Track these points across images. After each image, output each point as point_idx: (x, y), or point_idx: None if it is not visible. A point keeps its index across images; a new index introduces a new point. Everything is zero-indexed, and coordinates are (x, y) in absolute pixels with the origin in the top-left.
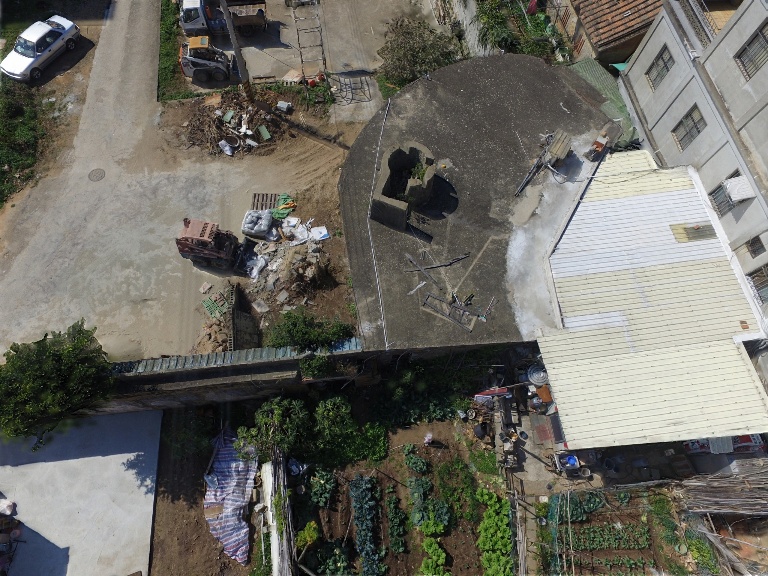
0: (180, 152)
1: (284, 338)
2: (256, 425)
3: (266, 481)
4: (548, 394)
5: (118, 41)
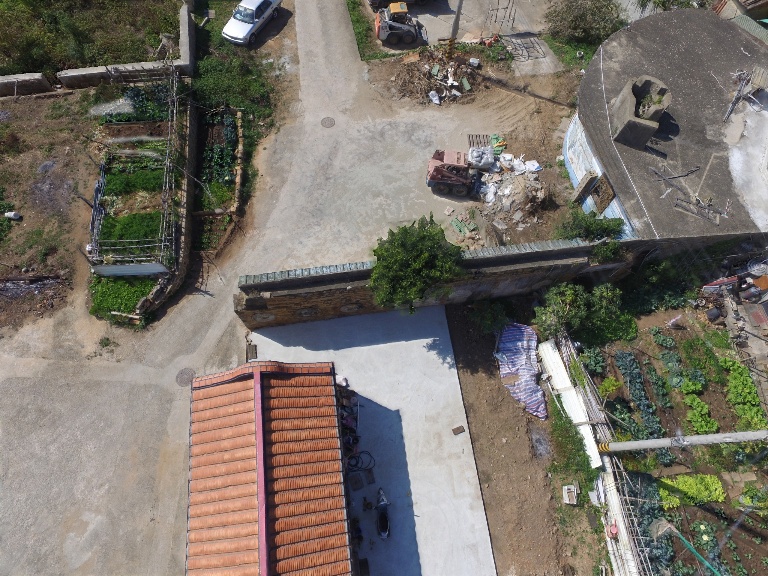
0: (394, 102)
1: (575, 231)
2: (549, 305)
3: (545, 357)
4: (767, 282)
5: (312, 10)
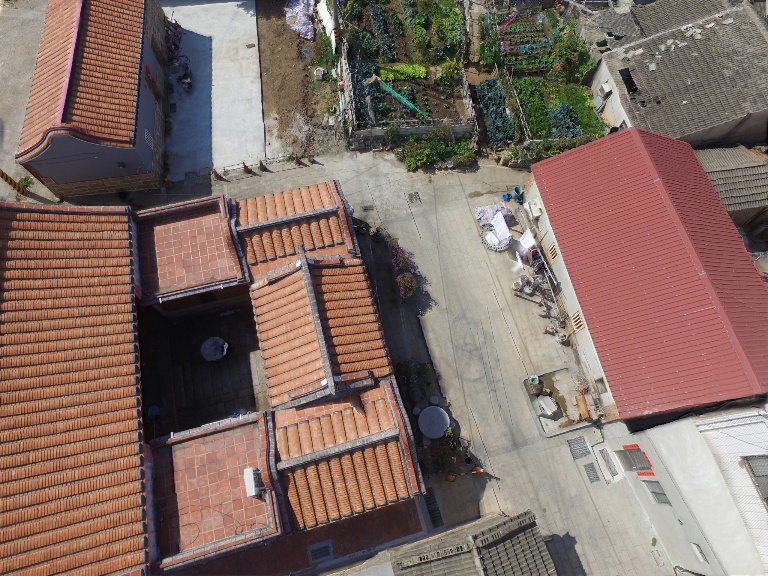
0: None
1: None
2: None
3: (320, 10)
4: None
5: None
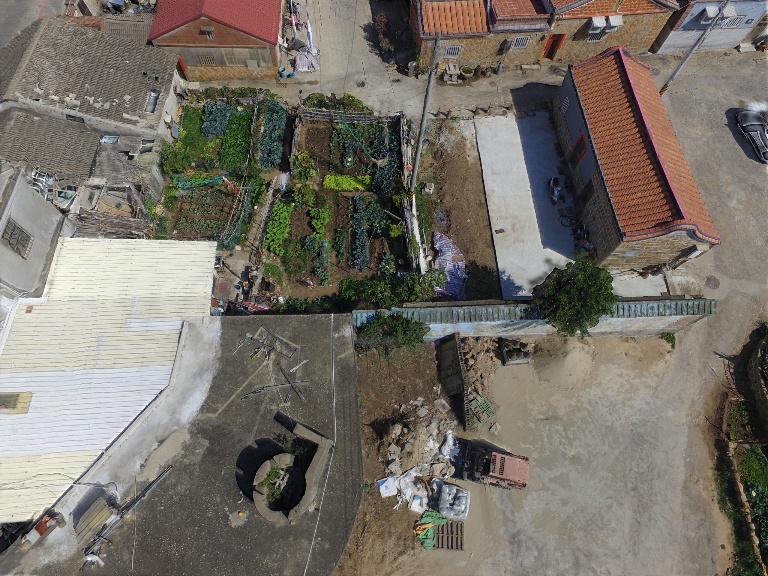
0: None
1: None
2: None
3: None
4: None
5: None
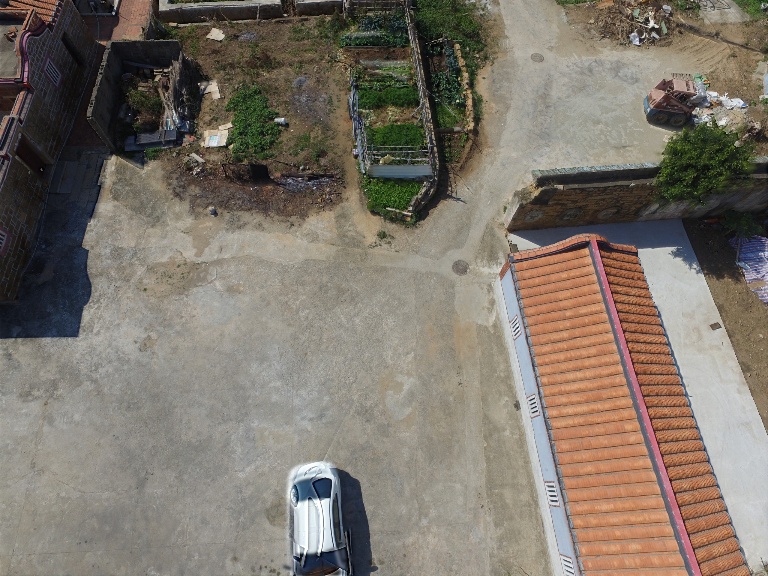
0: (595, 43)
1: None
2: None
3: None
4: None
5: None
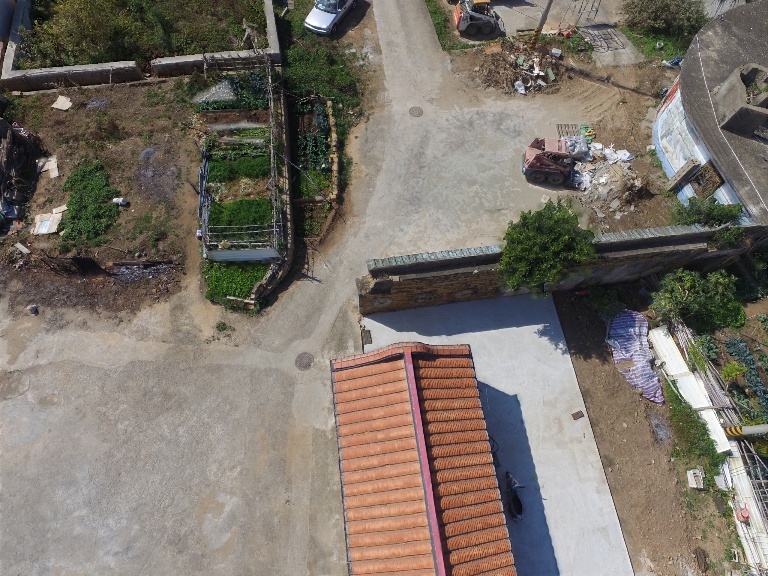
0: (479, 92)
1: (693, 217)
2: (666, 291)
3: (657, 343)
4: None
5: (389, 1)
